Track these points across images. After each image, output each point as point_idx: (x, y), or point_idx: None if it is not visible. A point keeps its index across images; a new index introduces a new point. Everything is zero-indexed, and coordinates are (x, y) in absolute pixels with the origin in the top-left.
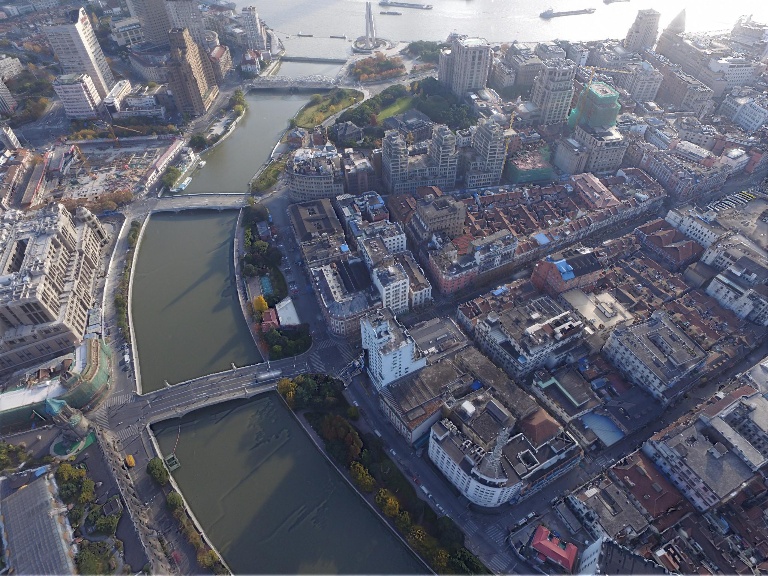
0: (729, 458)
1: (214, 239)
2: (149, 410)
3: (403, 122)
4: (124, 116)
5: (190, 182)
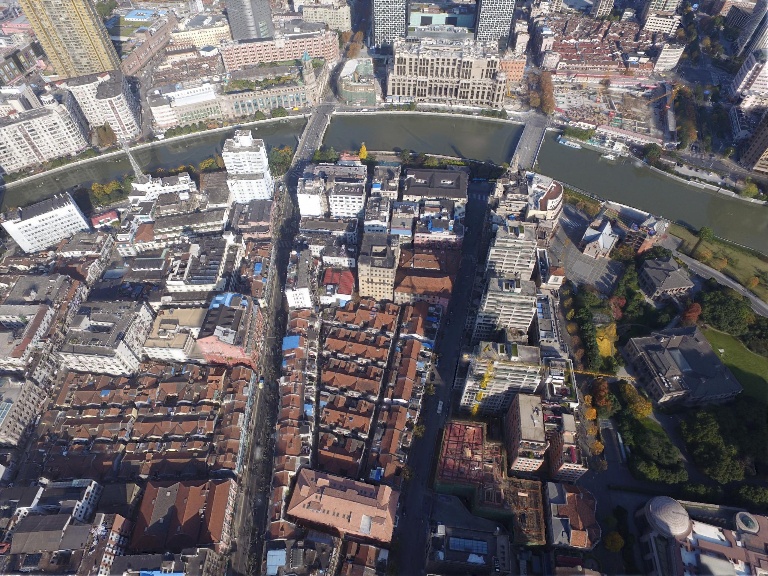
0: (22, 302)
1: (470, 152)
2: (320, 114)
3: (677, 346)
4: (731, 113)
5: (573, 147)
